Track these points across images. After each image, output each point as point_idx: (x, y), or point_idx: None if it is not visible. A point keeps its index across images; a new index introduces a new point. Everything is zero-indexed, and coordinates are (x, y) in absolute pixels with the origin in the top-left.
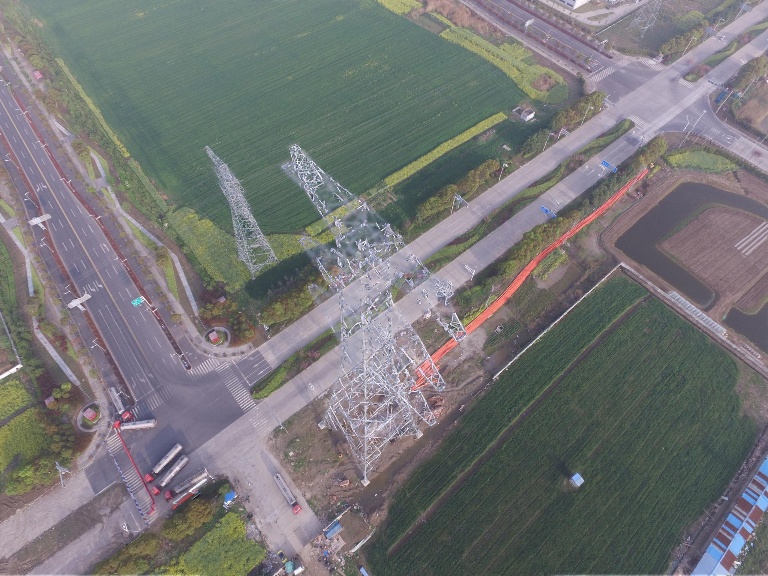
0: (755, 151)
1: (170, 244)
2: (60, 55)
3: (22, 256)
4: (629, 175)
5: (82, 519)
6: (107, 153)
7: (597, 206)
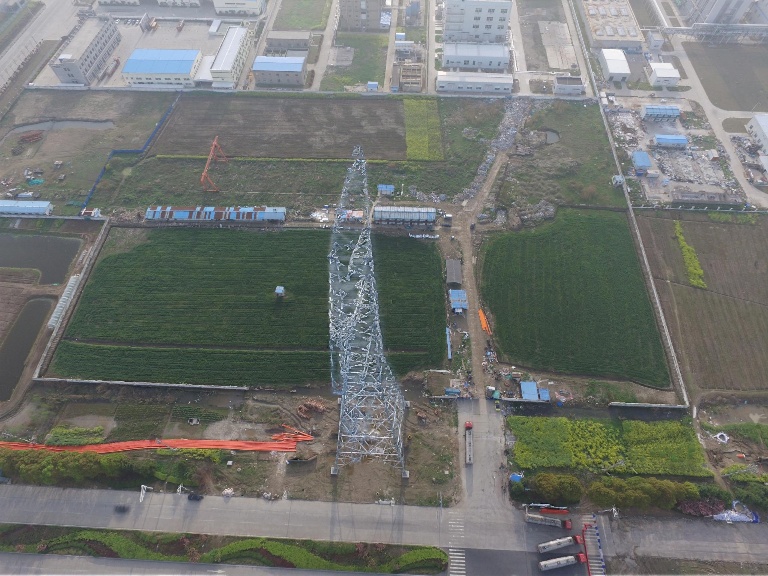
0: None
1: None
2: None
3: None
4: None
5: (654, 573)
6: None
7: None
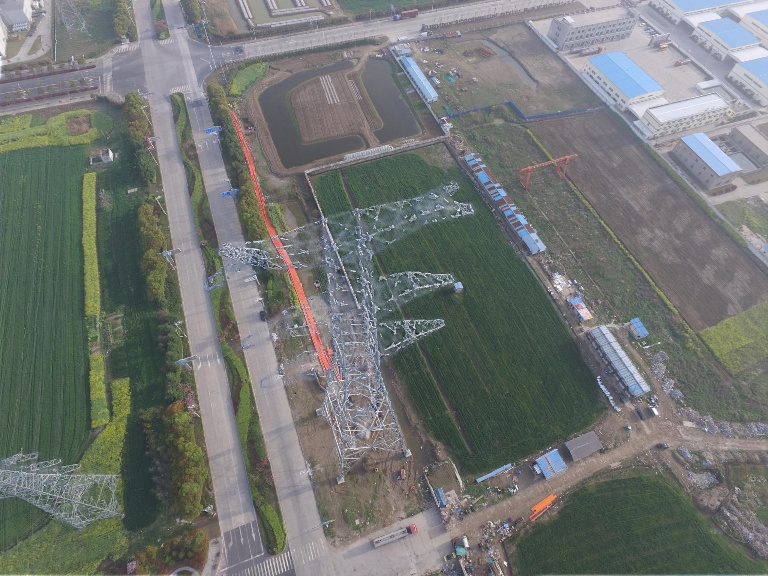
0: None
1: None
2: None
3: None
4: (229, 124)
5: None
6: None
7: (244, 159)
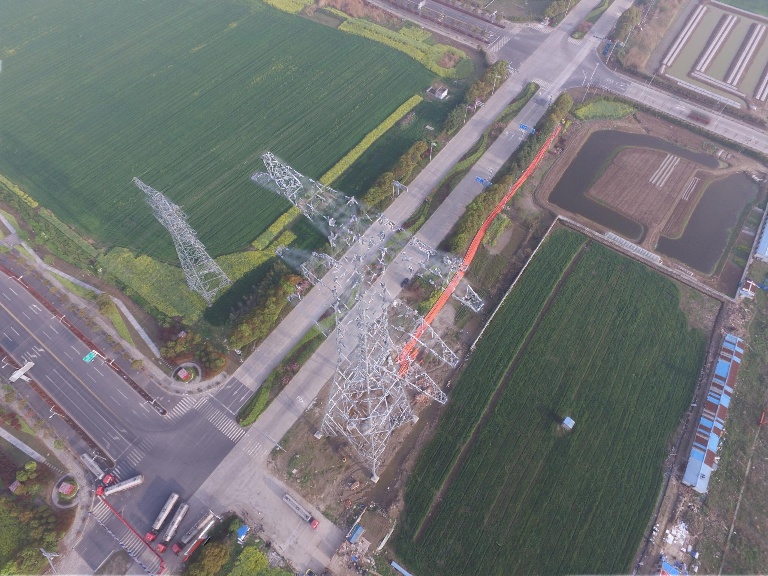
0: (646, 93)
1: (110, 289)
2: None
3: None
4: (546, 134)
5: None
6: (11, 207)
7: (525, 168)
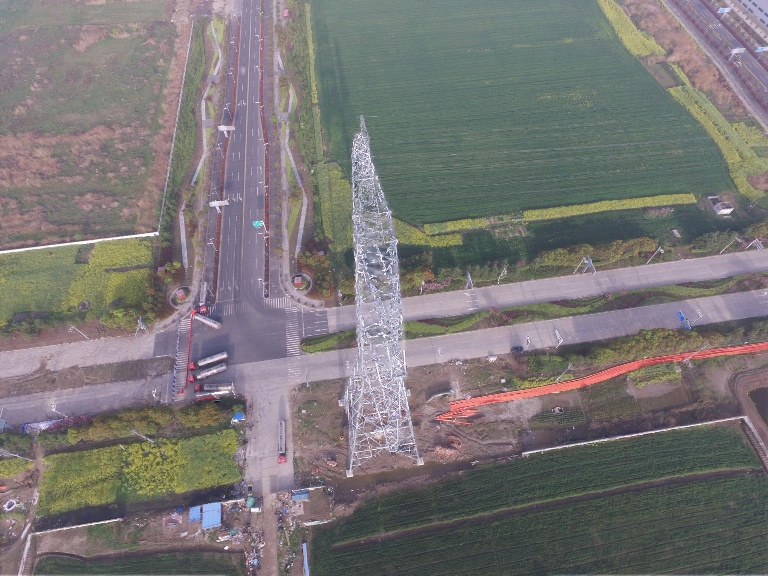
0: None
1: (308, 189)
2: (311, 1)
3: (202, 151)
4: None
5: (135, 369)
6: (301, 94)
7: (752, 341)
